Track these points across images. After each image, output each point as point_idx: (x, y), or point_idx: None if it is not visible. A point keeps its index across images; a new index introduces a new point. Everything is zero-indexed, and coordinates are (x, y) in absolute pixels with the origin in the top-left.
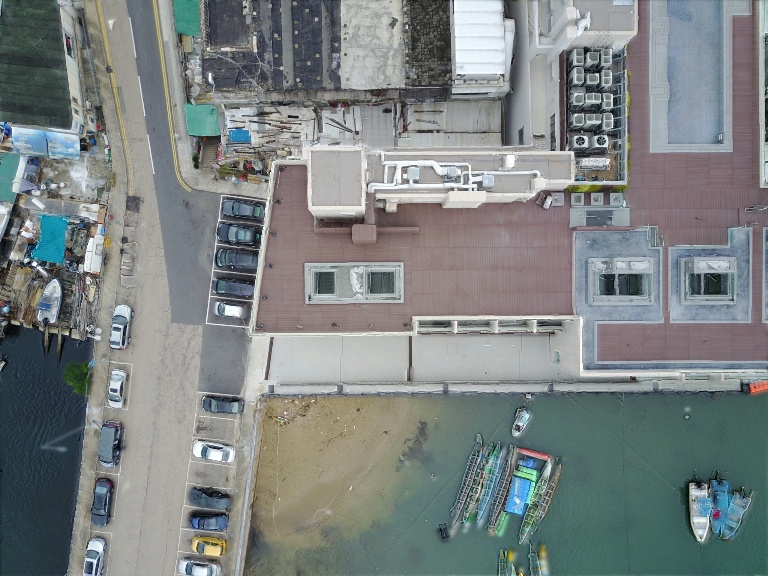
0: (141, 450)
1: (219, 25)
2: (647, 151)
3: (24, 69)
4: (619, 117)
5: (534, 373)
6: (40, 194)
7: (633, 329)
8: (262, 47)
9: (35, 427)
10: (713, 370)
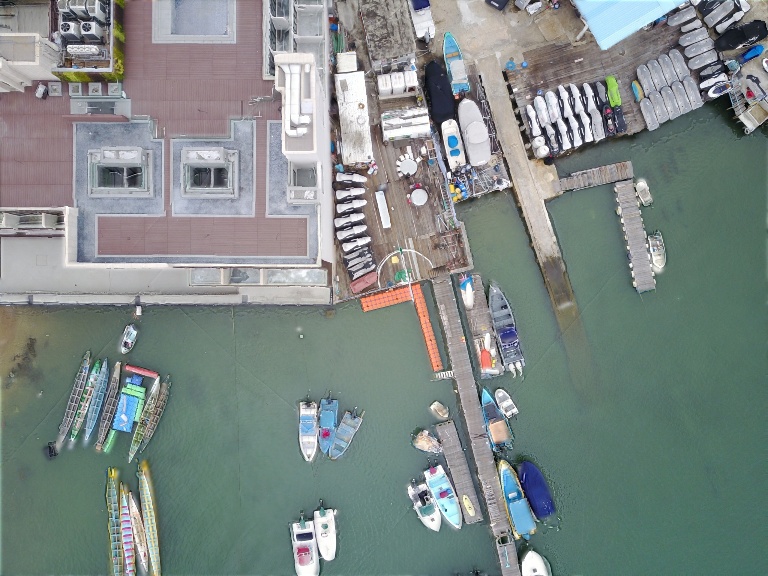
0: None
1: None
2: (149, 42)
3: None
4: None
5: (124, 286)
6: None
7: (134, 222)
8: None
9: None
10: (213, 264)
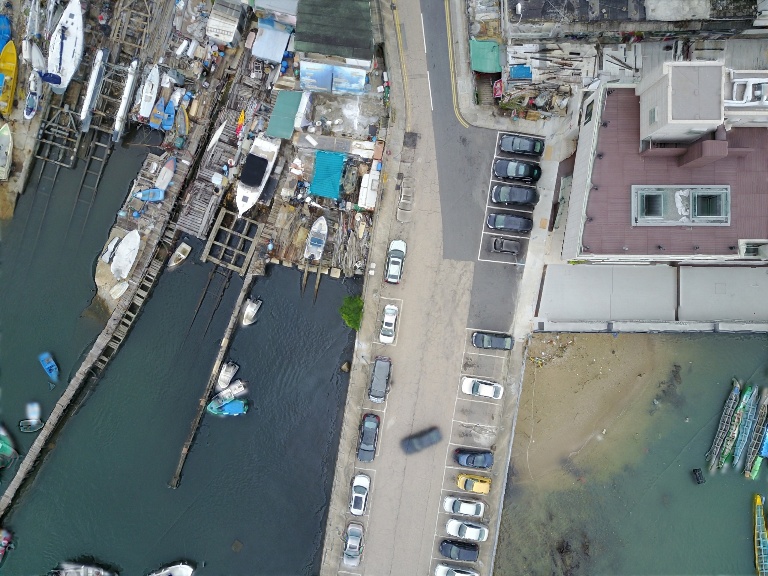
0: (408, 387)
1: None
2: None
3: (328, 1)
4: None
5: None
6: (315, 131)
7: None
8: None
9: (282, 368)
10: None
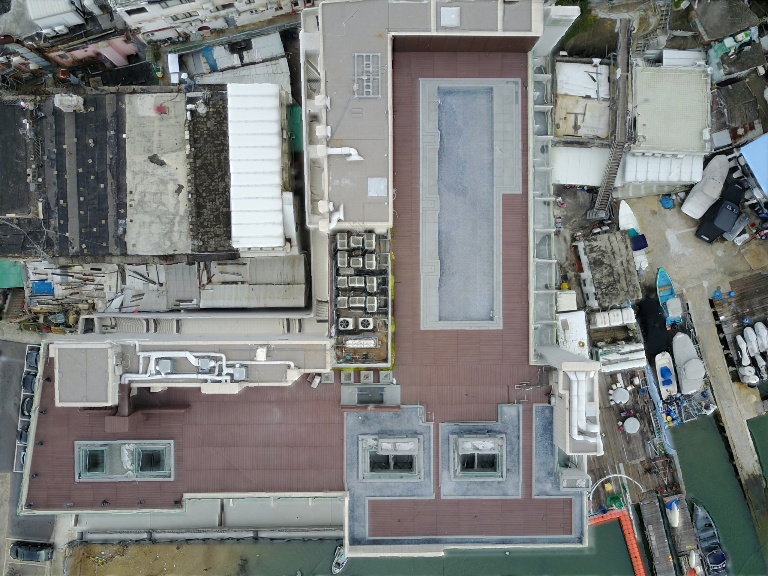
0: None
1: (4, 191)
2: (418, 328)
3: None
4: (386, 298)
5: None
6: None
7: (404, 505)
8: (48, 213)
9: None
10: (482, 546)
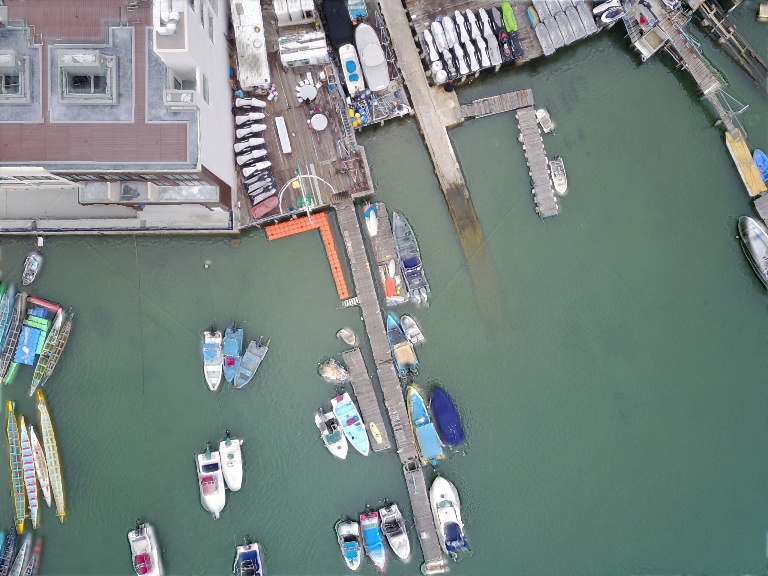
0: None
1: None
2: None
3: None
4: None
5: (21, 212)
6: None
7: (12, 129)
8: None
9: None
10: (91, 170)
